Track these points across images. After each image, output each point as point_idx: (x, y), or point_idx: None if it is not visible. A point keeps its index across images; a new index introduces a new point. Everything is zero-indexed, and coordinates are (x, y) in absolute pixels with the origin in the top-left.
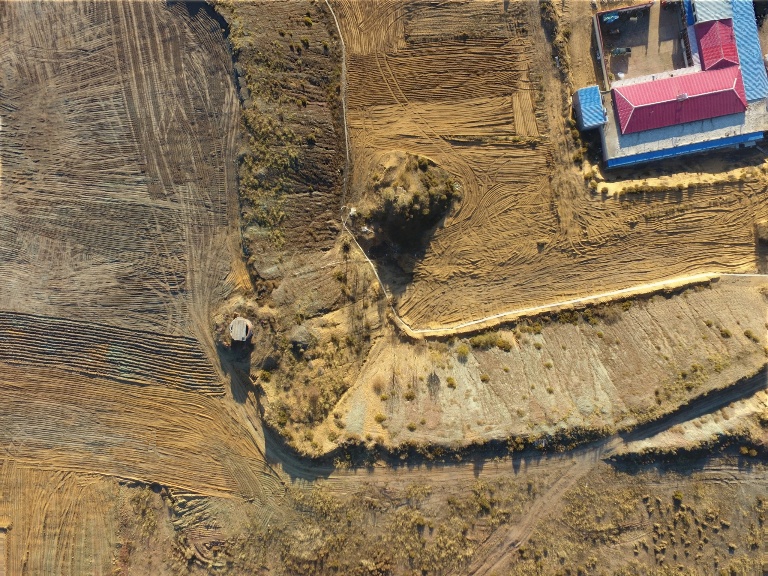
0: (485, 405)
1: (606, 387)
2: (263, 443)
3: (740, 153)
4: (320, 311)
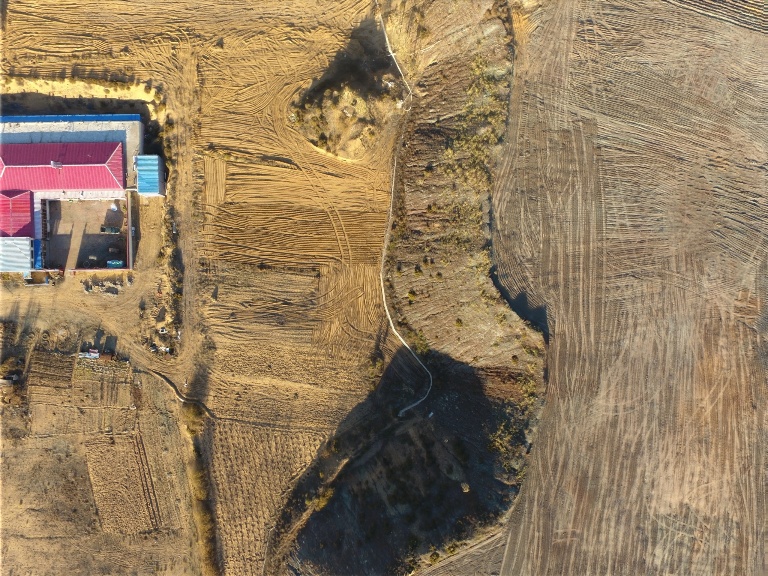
0: None
1: None
2: None
3: (8, 111)
4: None
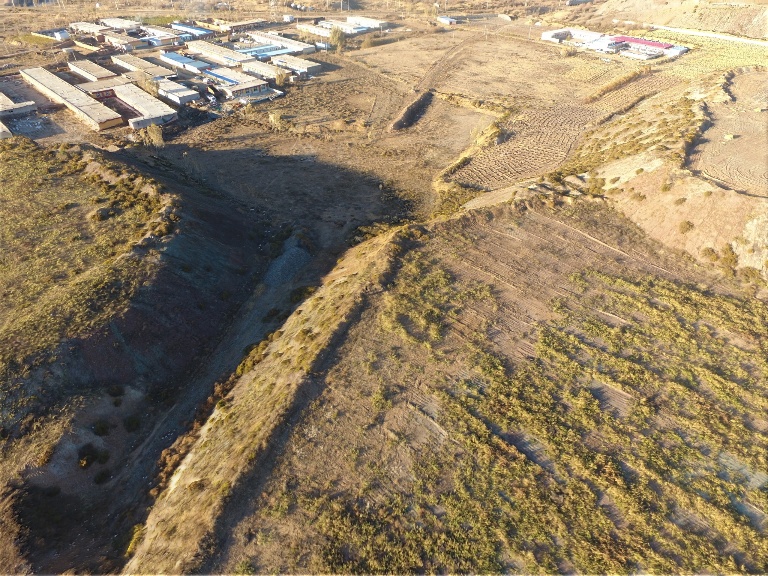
0: None
1: (761, 15)
2: None
3: None
4: None
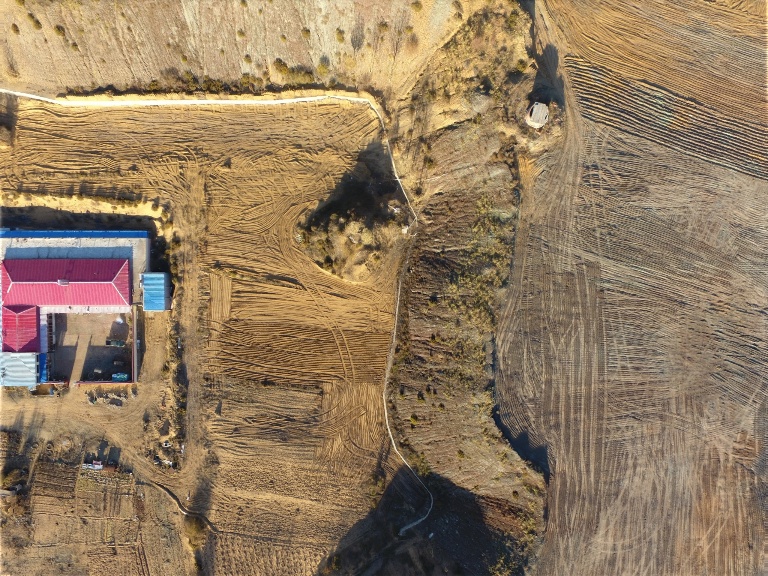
0: (311, 2)
1: None
2: (537, 0)
3: (16, 223)
4: (456, 128)
